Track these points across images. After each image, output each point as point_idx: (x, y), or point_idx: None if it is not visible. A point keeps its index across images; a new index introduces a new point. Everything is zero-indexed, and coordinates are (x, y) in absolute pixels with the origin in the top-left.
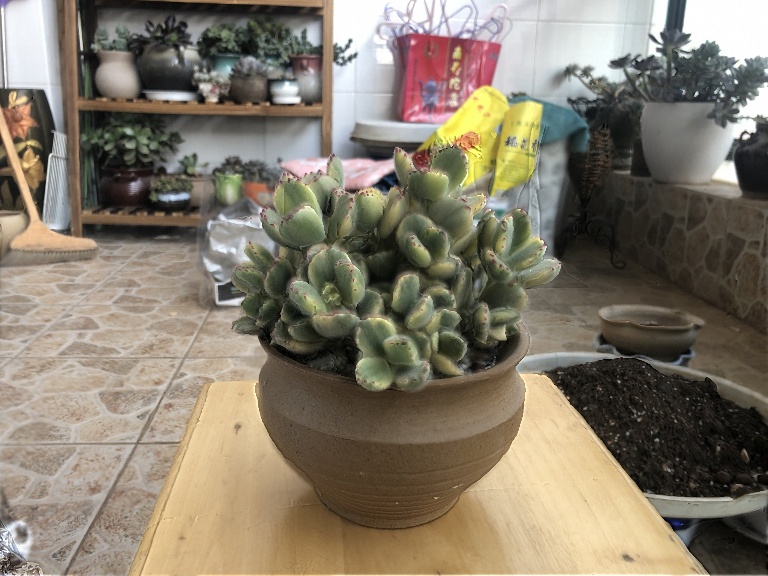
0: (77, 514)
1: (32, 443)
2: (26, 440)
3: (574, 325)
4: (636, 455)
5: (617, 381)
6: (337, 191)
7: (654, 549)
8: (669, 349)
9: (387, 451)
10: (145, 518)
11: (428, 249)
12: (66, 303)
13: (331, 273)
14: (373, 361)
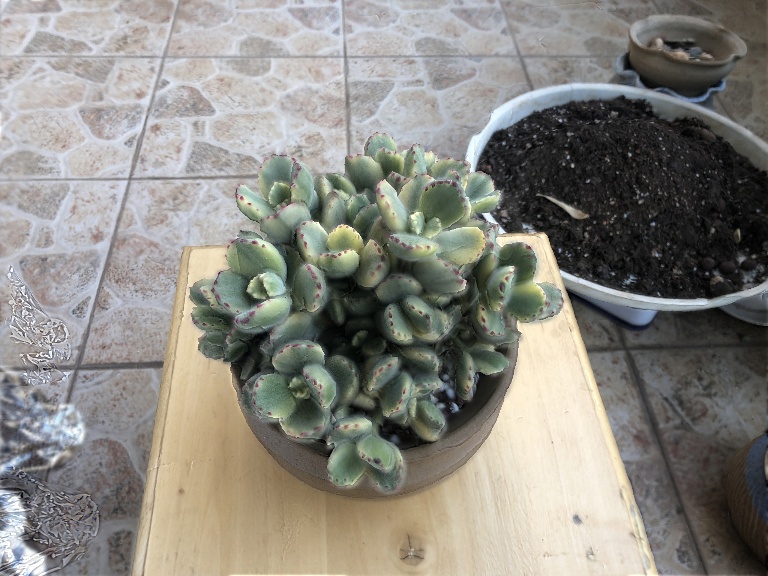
0: (86, 266)
1: (23, 178)
2: (16, 174)
3: (603, 9)
4: (628, 239)
5: (628, 154)
6: (303, 231)
7: (602, 508)
8: (698, 84)
9: (362, 489)
10: (151, 270)
11: (410, 321)
12: None
13: (298, 365)
14: (346, 448)
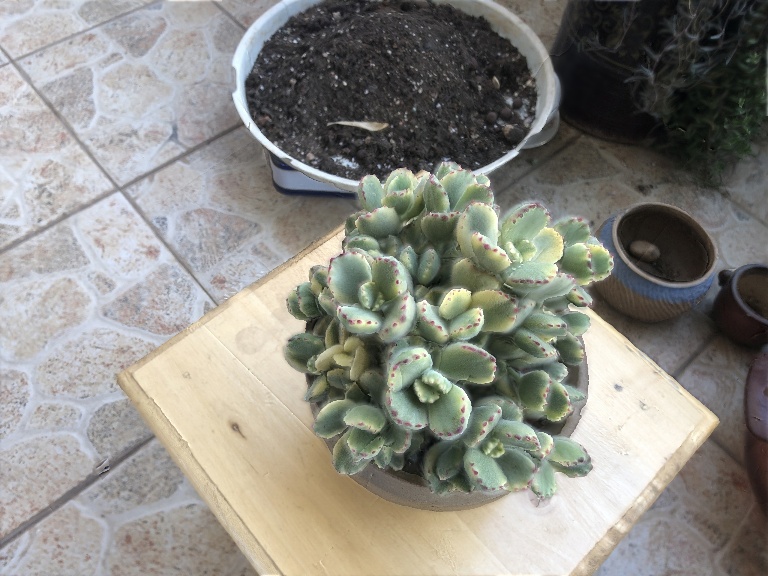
0: None
1: None
2: None
3: None
4: (427, 128)
5: (388, 52)
6: None
7: (626, 367)
8: None
9: None
10: None
11: (541, 336)
12: None
13: None
14: None
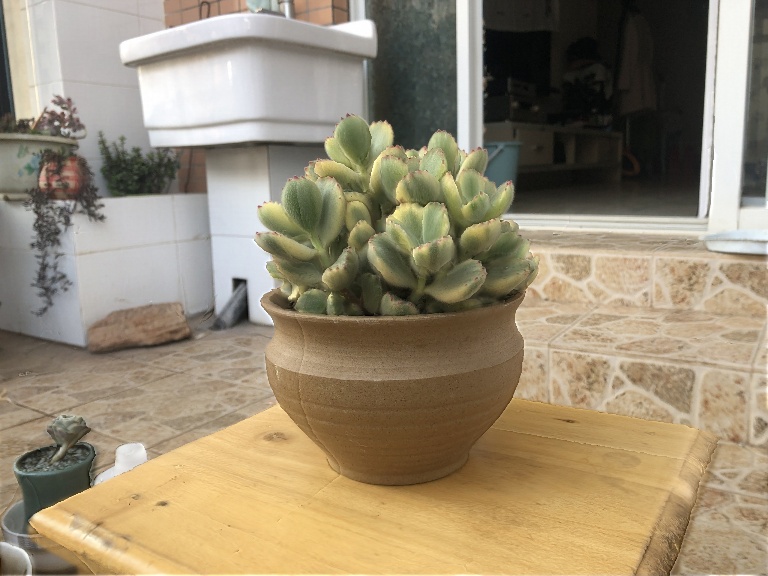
0: None
1: None
2: None
3: None
4: None
5: None
6: None
7: (141, 522)
8: None
9: None
10: None
11: None
12: None
13: None
14: None
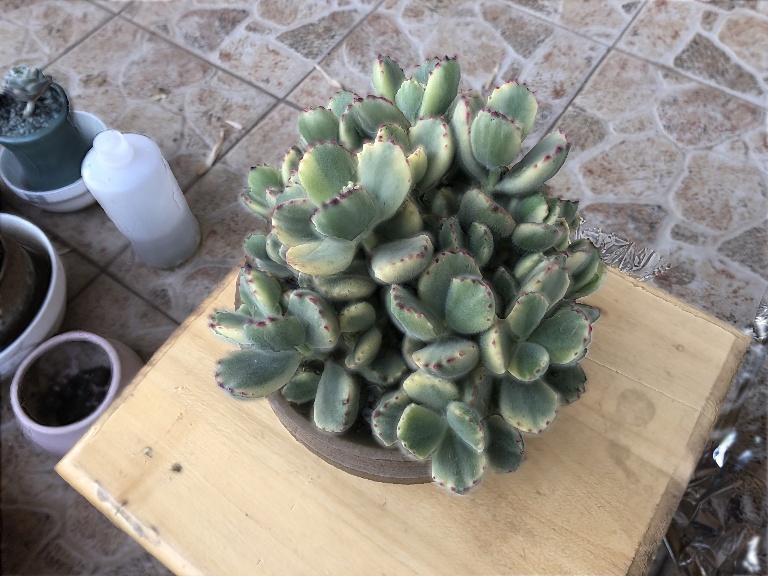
0: None
1: None
2: None
3: None
4: None
5: None
6: None
7: (163, 500)
8: None
9: None
10: None
11: None
12: None
13: None
14: None
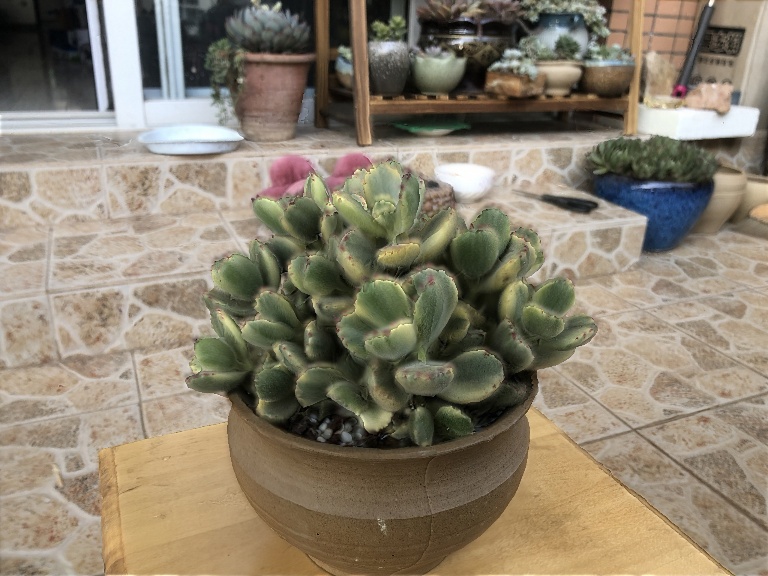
0: None
1: (568, 378)
2: (568, 373)
3: None
4: None
5: None
6: None
7: None
8: None
9: None
10: None
11: None
12: (744, 283)
13: None
14: None
